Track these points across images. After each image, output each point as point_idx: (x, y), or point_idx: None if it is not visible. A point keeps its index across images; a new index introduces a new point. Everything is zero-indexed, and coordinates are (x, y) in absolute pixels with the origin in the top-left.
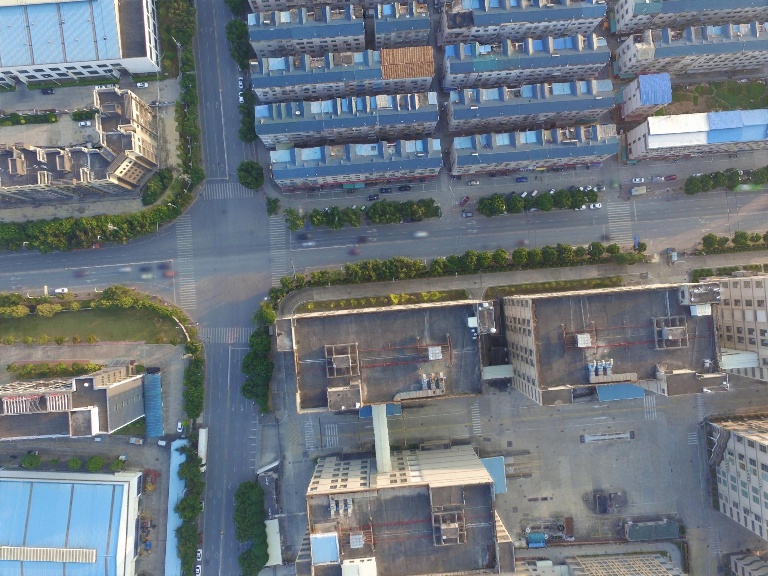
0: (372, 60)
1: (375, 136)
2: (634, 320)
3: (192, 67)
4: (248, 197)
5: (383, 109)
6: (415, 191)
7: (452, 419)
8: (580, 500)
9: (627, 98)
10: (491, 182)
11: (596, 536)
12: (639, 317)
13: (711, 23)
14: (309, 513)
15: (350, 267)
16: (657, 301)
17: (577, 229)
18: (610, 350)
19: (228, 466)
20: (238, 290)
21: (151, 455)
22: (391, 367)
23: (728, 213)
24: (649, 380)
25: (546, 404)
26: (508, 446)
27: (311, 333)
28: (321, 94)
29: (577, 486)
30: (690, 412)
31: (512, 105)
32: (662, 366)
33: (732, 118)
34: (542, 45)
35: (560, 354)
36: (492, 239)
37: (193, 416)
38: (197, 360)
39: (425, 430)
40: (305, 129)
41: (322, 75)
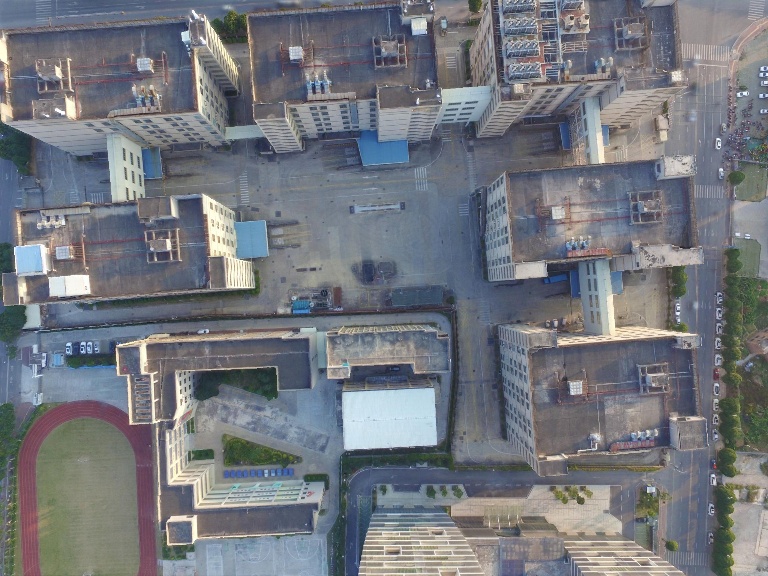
0: None
1: None
2: (355, 40)
3: None
4: None
5: None
6: None
7: (220, 189)
8: (349, 271)
9: None
10: None
11: (365, 307)
12: (360, 37)
13: None
14: (21, 230)
15: None
16: (379, 21)
17: None
18: (330, 70)
19: None
20: None
21: None
22: (106, 84)
23: None
24: (364, 96)
25: (258, 118)
26: (277, 216)
27: (24, 50)
28: None
29: (346, 257)
30: (462, 183)
31: None
32: None
33: None
34: None
35: (278, 73)
36: (262, 8)
37: None
38: None
39: None
40: None
41: None
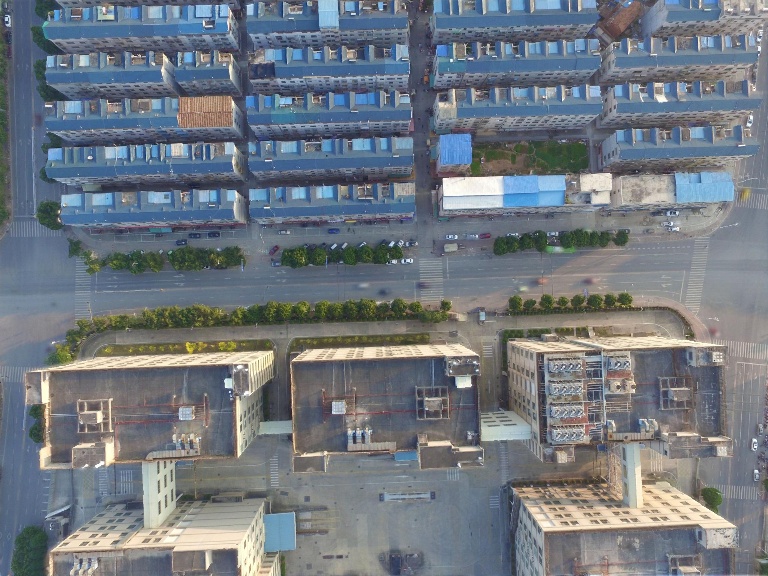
0: (170, 108)
1: (182, 181)
2: (397, 388)
3: (1, 104)
4: (56, 236)
5: (178, 157)
6: (225, 238)
7: (250, 471)
8: (376, 560)
9: (437, 155)
10: (303, 232)
11: None
12: (403, 385)
13: (530, 82)
14: (53, 570)
15: (145, 314)
16: (422, 370)
17: (387, 283)
18: (371, 417)
19: (19, 508)
20: (40, 330)
21: None
22: (146, 425)
23: (542, 274)
24: None
25: (298, 471)
26: (305, 501)
27: (66, 386)
28: (128, 137)
29: (374, 545)
30: (493, 475)
31: (308, 159)
32: (423, 436)
33: (528, 183)
34: (344, 100)
35: (319, 419)
36: (301, 290)
37: None
38: None
39: (222, 481)
40: (97, 174)
41: (116, 121)
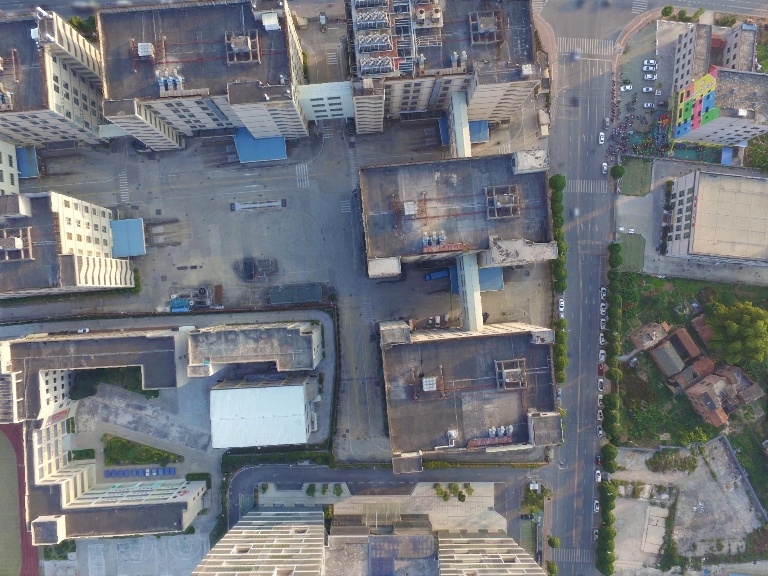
0: None
1: None
2: (208, 36)
3: None
4: None
5: None
6: None
7: (99, 187)
8: (230, 268)
9: None
10: None
11: (246, 305)
12: (213, 33)
13: None
14: None
15: None
16: (232, 17)
17: None
18: (183, 66)
19: None
20: None
21: None
22: None
23: None
24: (216, 92)
25: (108, 115)
26: (157, 214)
27: None
28: None
29: (227, 254)
30: (343, 180)
31: None
32: None
33: None
34: None
35: (131, 70)
36: None
37: None
38: None
39: None
40: None
41: None
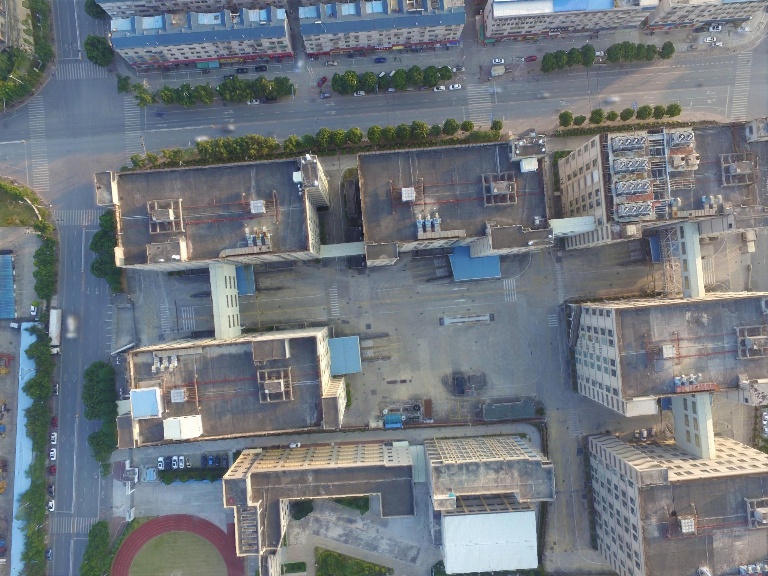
0: None
1: None
2: (464, 177)
3: None
4: (102, 78)
5: None
6: (272, 72)
7: (310, 302)
8: (439, 382)
9: None
10: (349, 63)
11: (455, 418)
12: (469, 174)
13: None
14: (133, 371)
15: (199, 143)
16: (487, 158)
17: (437, 111)
18: (439, 207)
19: (83, 349)
20: (92, 172)
21: (5, 338)
22: (216, 224)
23: (589, 95)
24: (476, 235)
25: (371, 258)
26: (367, 329)
27: (135, 189)
28: None
29: (436, 369)
30: (550, 294)
31: None
32: (491, 223)
33: None
34: None
35: (388, 211)
36: (351, 121)
37: (43, 296)
38: (47, 239)
39: (283, 313)
40: None
41: None
